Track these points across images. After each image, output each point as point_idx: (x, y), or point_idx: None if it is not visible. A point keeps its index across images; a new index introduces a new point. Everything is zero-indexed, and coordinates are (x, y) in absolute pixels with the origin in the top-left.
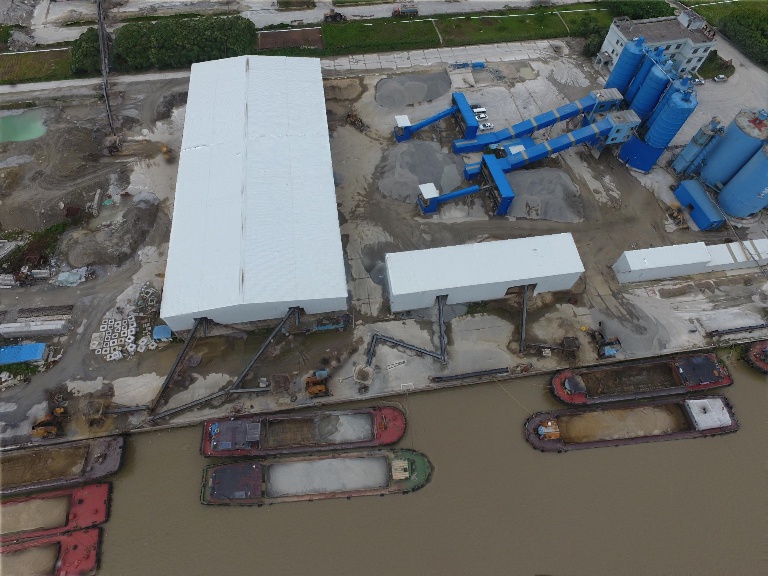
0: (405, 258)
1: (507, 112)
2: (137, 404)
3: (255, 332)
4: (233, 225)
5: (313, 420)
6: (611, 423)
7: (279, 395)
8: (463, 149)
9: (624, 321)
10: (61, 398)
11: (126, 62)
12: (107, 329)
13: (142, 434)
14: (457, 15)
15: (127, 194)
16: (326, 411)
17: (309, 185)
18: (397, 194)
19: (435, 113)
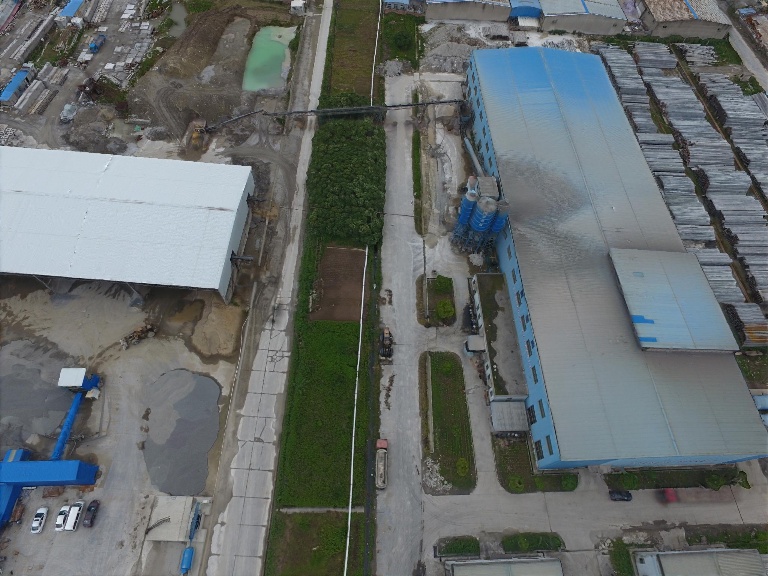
0: None
1: (58, 575)
2: None
3: None
4: None
5: None
6: None
7: None
8: None
9: None
10: None
11: None
12: (5, 131)
13: None
14: (366, 574)
15: (138, 138)
16: None
17: None
18: None
19: (114, 447)
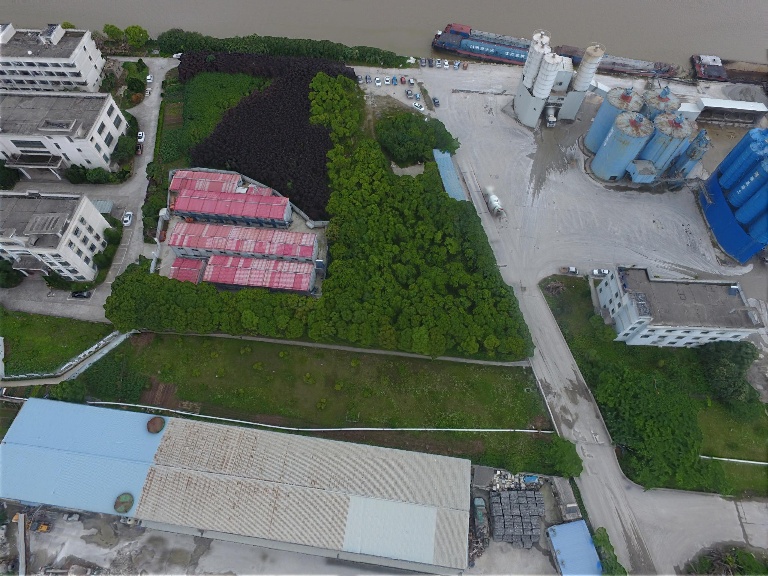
0: None
1: None
2: None
3: None
4: None
5: None
6: (767, 67)
7: None
8: None
9: (751, 101)
10: None
11: None
12: None
13: None
14: None
15: None
16: None
17: None
18: None
19: None
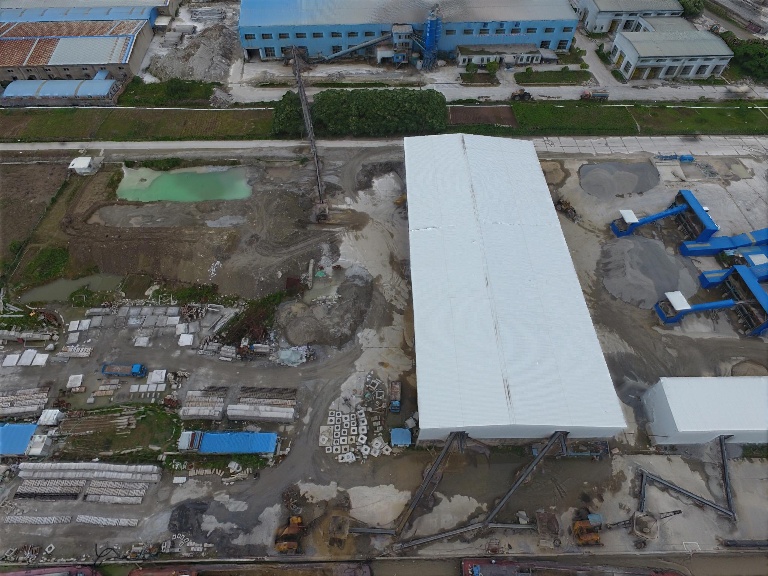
0: (683, 385)
1: (729, 213)
2: (378, 523)
3: (498, 448)
4: (484, 324)
5: (576, 571)
6: None
7: (540, 535)
8: (693, 252)
9: None
10: (296, 504)
11: (326, 127)
12: (335, 423)
13: (384, 562)
14: (649, 103)
15: (340, 267)
16: (597, 565)
17: (554, 284)
18: (629, 297)
19: (649, 207)
